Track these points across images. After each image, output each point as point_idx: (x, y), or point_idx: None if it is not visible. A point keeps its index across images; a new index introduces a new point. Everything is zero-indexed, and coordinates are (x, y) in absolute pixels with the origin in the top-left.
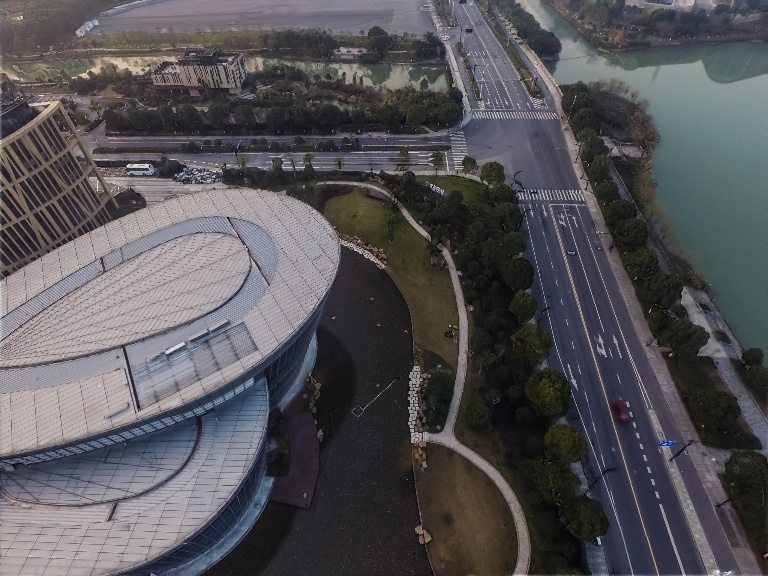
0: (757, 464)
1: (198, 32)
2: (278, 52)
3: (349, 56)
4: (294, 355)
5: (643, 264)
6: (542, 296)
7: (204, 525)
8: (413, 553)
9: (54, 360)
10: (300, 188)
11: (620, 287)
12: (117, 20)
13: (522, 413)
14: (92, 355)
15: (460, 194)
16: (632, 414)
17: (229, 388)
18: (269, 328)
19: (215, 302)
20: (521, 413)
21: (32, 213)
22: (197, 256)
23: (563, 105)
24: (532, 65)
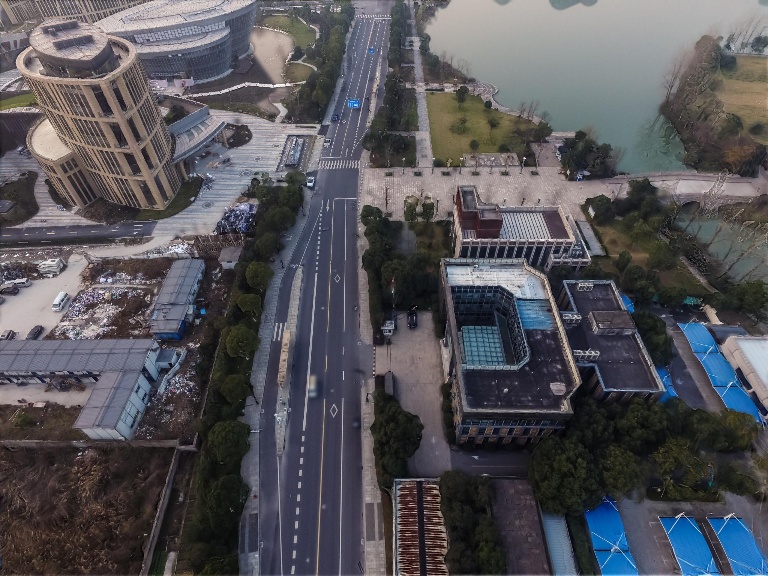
0: (394, 47)
1: None
2: None
3: None
4: (241, 27)
5: None
6: None
7: (209, 43)
8: (279, 78)
9: (156, 17)
10: None
11: None
12: None
13: None
14: (169, 16)
15: None
16: None
17: (217, 20)
18: (230, 8)
19: (211, 6)
20: None
21: (128, 5)
22: (204, 0)
23: None
24: None
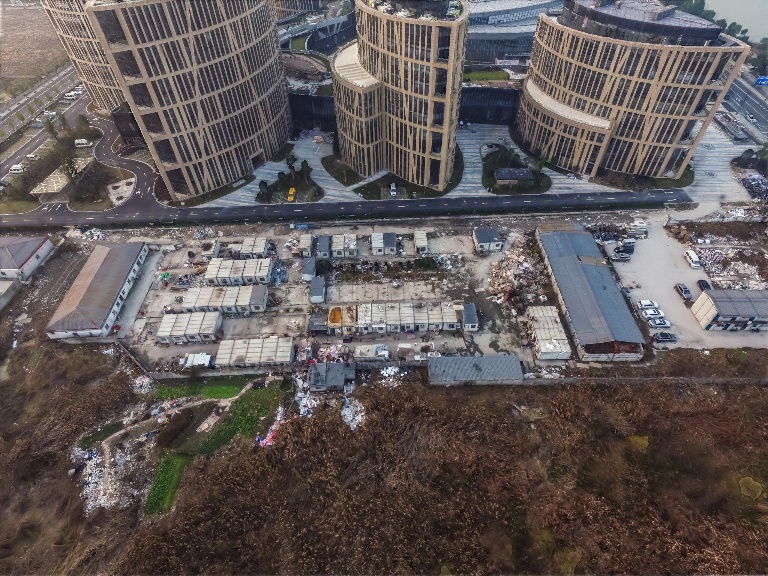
0: None
1: None
2: None
3: None
4: None
5: (688, 4)
6: None
7: None
8: None
9: None
10: None
11: None
12: None
13: None
14: None
15: None
16: None
17: (561, 2)
18: None
19: None
20: None
21: None
22: None
23: None
24: None
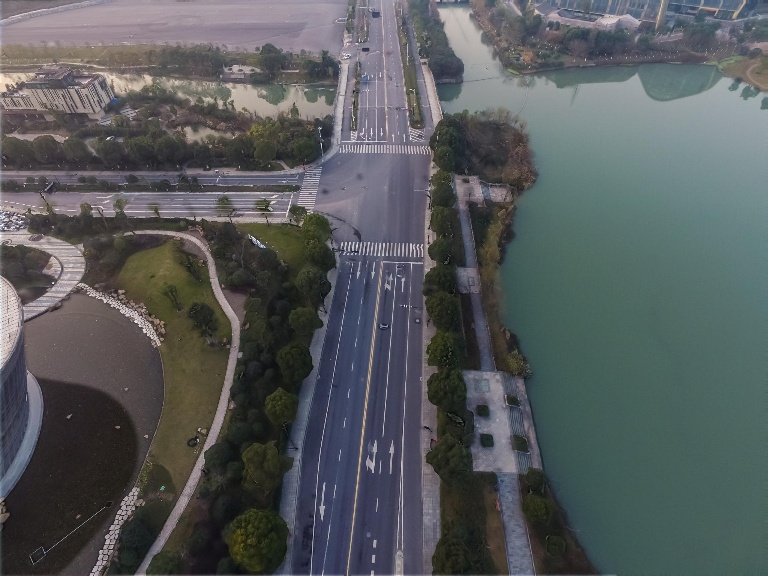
0: None
1: (87, 46)
2: (165, 70)
3: (239, 75)
4: None
5: (436, 352)
6: (329, 385)
7: None
8: None
9: None
10: (104, 240)
11: (423, 373)
12: (9, 31)
13: (220, 568)
14: None
15: (269, 253)
16: (375, 558)
17: None
18: None
19: None
20: (219, 567)
21: None
22: None
23: (430, 140)
24: (426, 89)
